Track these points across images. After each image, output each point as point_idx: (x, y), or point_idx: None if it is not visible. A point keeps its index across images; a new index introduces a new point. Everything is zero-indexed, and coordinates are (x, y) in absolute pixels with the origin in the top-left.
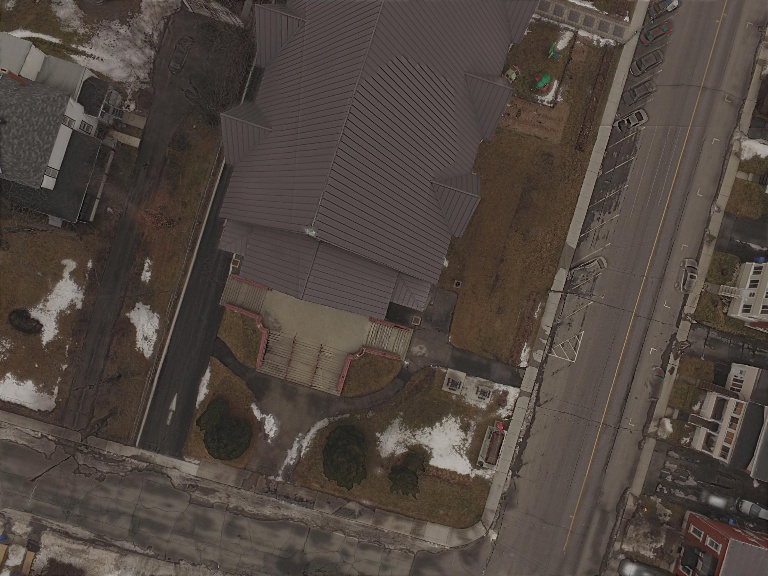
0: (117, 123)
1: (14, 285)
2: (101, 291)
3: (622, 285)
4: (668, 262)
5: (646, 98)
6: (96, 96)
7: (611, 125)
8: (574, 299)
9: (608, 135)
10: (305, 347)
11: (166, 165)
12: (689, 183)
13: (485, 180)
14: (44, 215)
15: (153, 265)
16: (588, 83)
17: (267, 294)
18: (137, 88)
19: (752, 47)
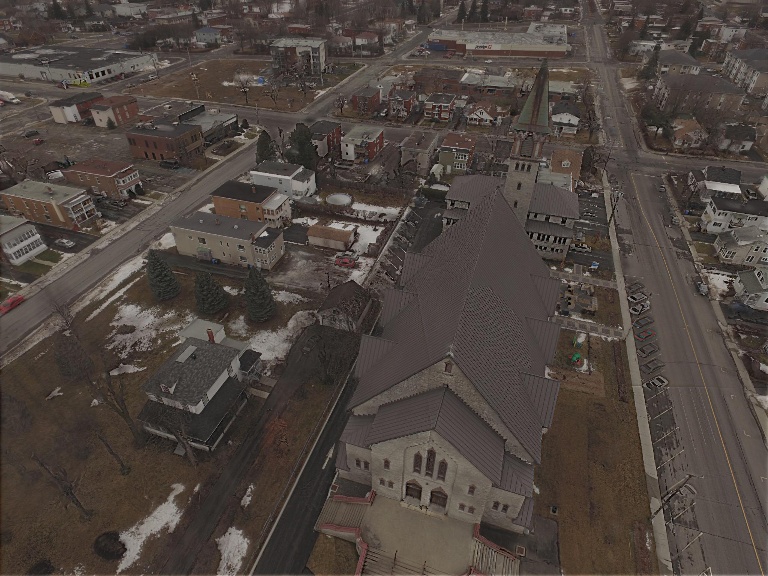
0: (255, 383)
1: (117, 507)
2: (198, 514)
3: (724, 515)
4: (757, 493)
5: (659, 370)
6: (251, 359)
7: (641, 386)
8: (681, 530)
9: (642, 392)
10: (405, 570)
11: (285, 411)
12: (732, 426)
13: (552, 422)
14: (173, 445)
15: (255, 490)
16: (610, 361)
17: (367, 509)
18: (275, 363)
19: (720, 342)
